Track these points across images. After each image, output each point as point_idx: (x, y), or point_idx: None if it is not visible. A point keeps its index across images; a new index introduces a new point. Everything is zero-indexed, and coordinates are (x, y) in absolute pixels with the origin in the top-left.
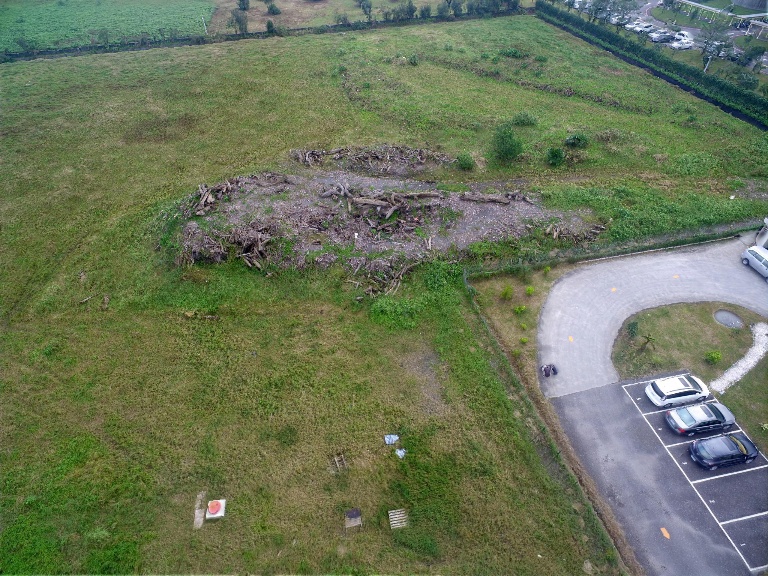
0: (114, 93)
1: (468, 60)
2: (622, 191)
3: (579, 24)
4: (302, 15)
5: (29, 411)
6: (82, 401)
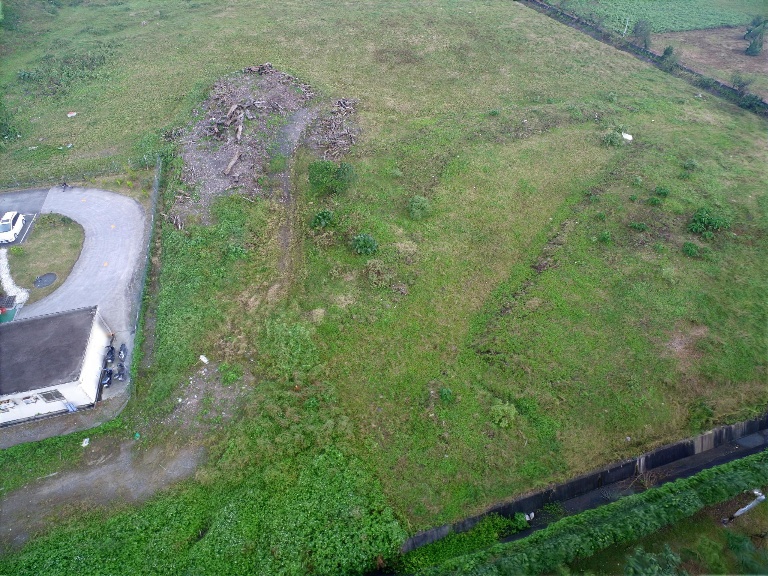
0: (461, 34)
1: None
2: (230, 248)
3: None
4: (764, 67)
5: None
6: None
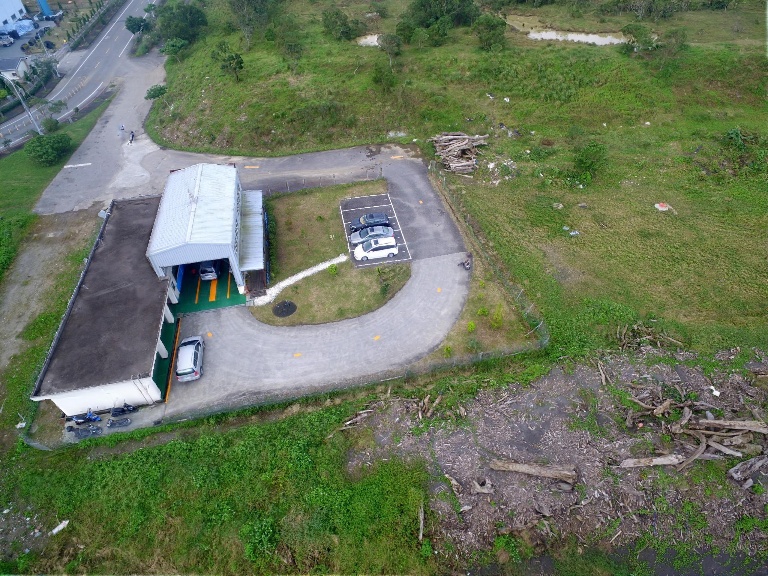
0: None
1: None
2: None
3: None
4: None
5: None
6: None
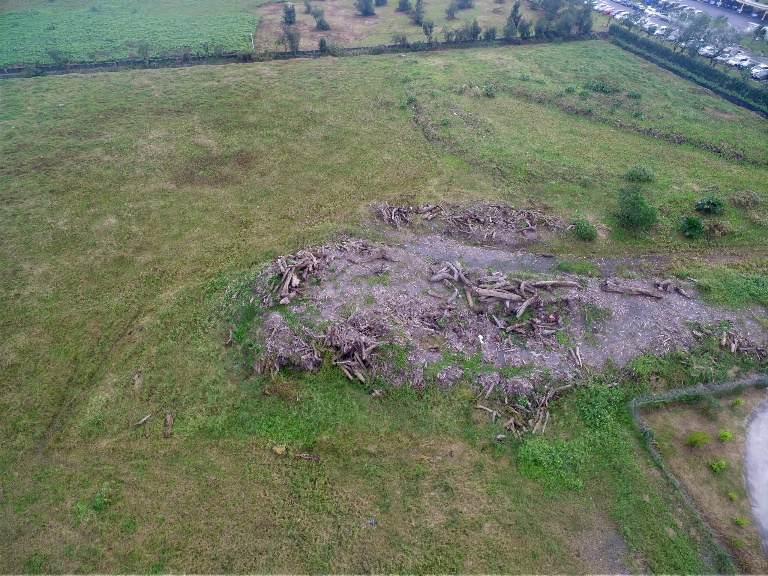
0: (158, 119)
1: (551, 94)
2: None
3: (665, 54)
4: (354, 32)
5: None
6: None
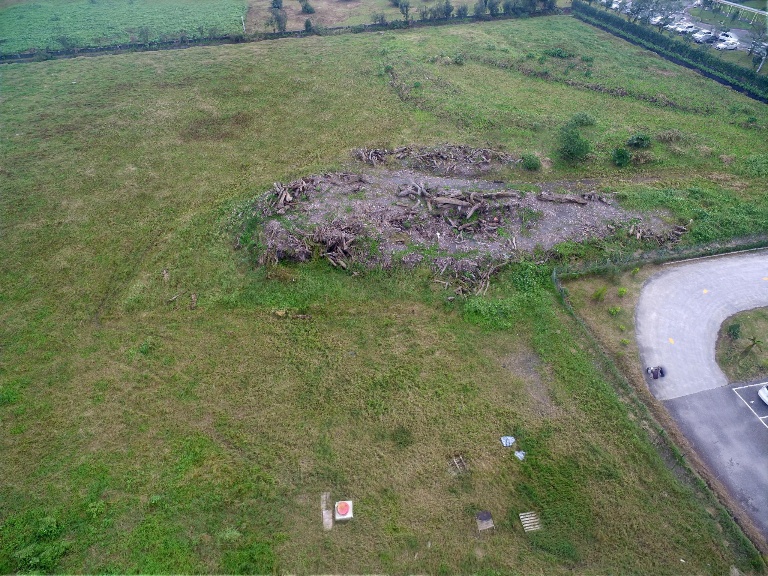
0: (162, 91)
1: (514, 60)
2: (697, 192)
3: (620, 24)
4: (337, 14)
5: (136, 410)
6: (188, 400)
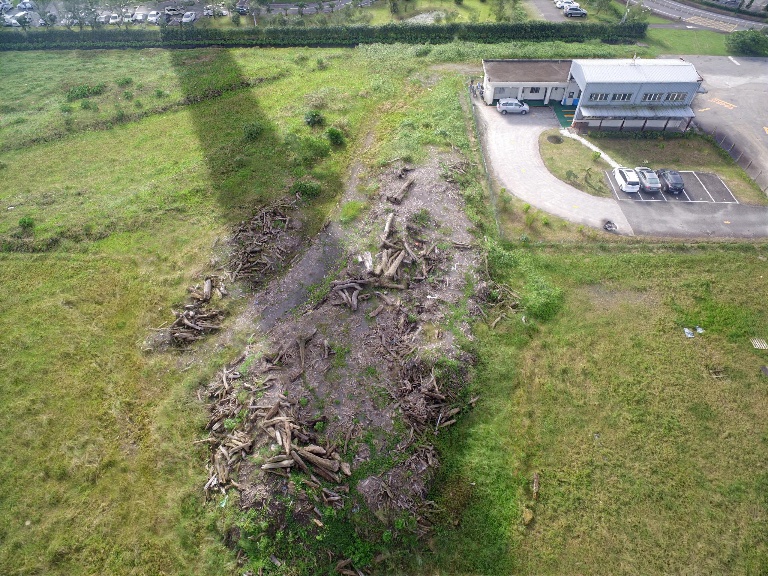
0: None
1: (57, 123)
2: (412, 123)
3: (72, 37)
4: None
5: None
6: None
